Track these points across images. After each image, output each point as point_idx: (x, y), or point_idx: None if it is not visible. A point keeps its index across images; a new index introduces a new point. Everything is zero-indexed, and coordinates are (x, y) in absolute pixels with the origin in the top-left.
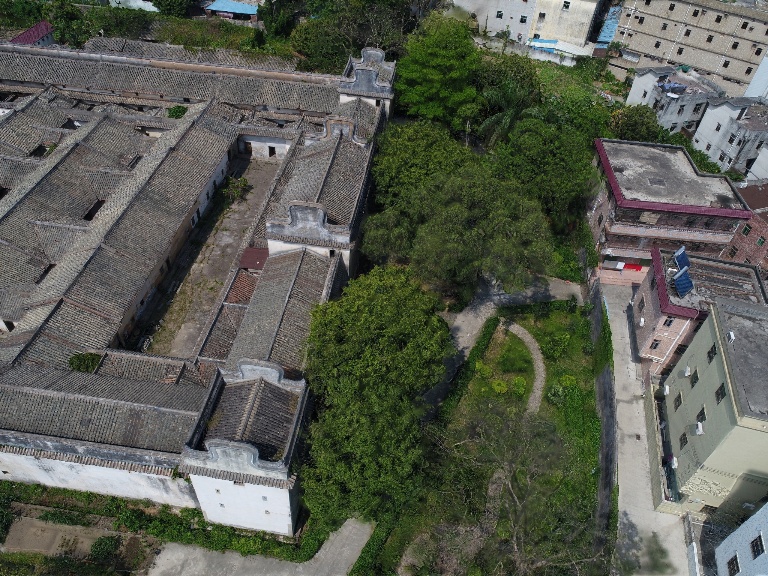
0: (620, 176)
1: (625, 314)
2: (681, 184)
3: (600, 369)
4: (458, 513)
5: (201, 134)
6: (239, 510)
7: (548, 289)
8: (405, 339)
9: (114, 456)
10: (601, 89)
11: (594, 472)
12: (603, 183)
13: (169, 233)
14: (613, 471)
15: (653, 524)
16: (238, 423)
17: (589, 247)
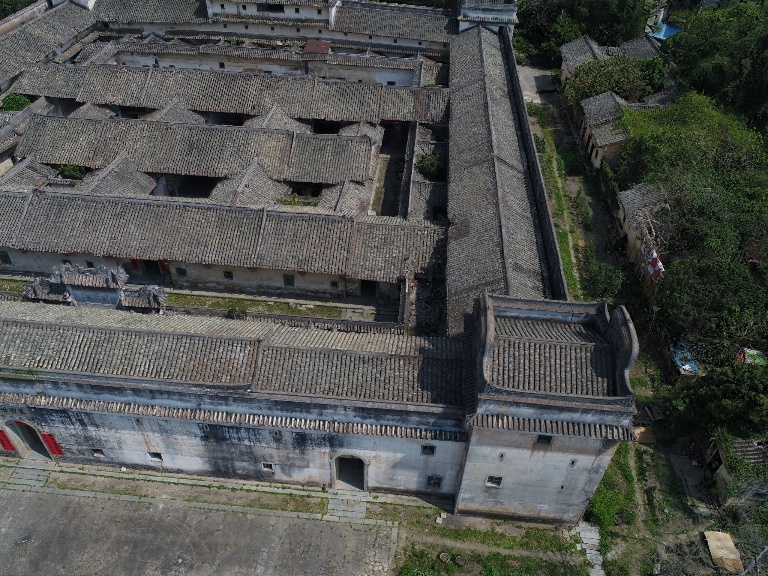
0: None
1: None
2: None
3: None
4: None
5: None
6: None
7: None
8: None
9: None
10: None
11: None
12: None
13: None
14: None
15: None
16: (494, 0)
17: None
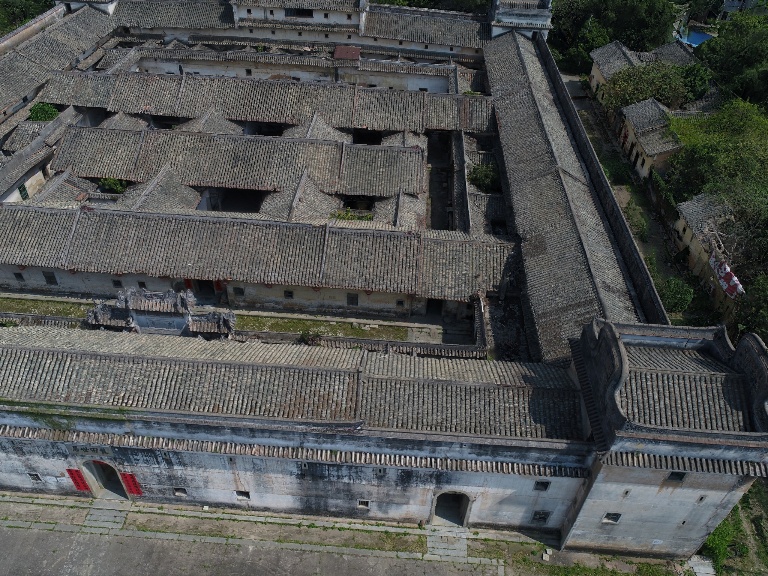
0: None
1: None
2: None
3: None
4: None
5: None
6: None
7: None
8: None
9: None
10: None
11: None
12: None
13: None
14: None
15: None
16: (527, 5)
17: None
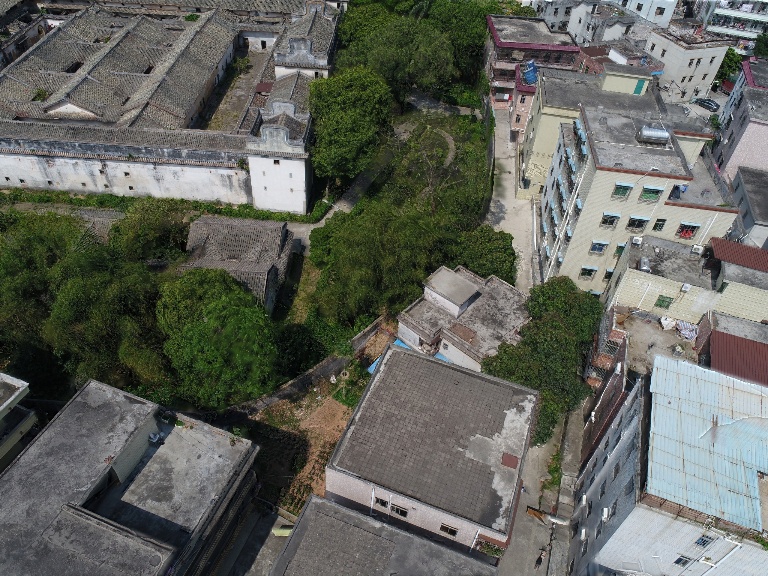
0: (500, 33)
1: (509, 123)
2: (539, 37)
3: (488, 142)
4: (401, 202)
5: (215, 26)
6: (275, 192)
7: (459, 112)
8: (364, 88)
9: (203, 157)
10: (504, 8)
11: (482, 187)
12: (491, 41)
13: (205, 78)
14: (489, 173)
15: (514, 204)
16: None
17: (484, 82)
